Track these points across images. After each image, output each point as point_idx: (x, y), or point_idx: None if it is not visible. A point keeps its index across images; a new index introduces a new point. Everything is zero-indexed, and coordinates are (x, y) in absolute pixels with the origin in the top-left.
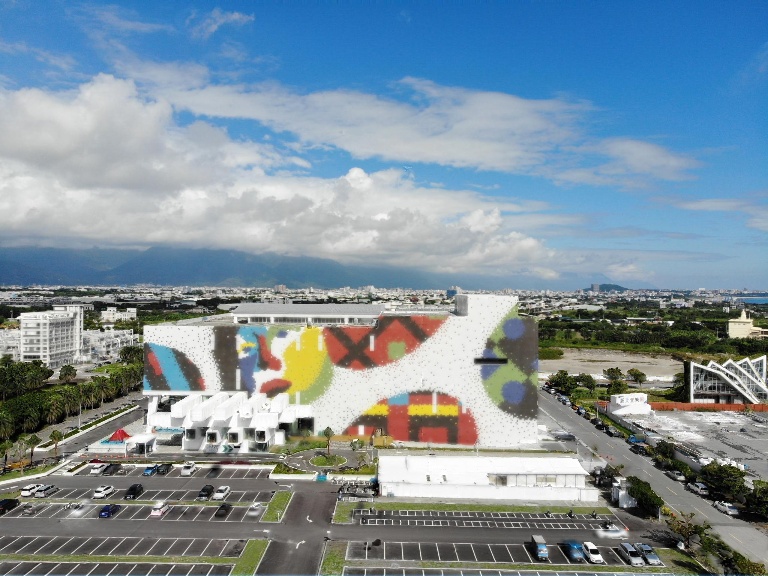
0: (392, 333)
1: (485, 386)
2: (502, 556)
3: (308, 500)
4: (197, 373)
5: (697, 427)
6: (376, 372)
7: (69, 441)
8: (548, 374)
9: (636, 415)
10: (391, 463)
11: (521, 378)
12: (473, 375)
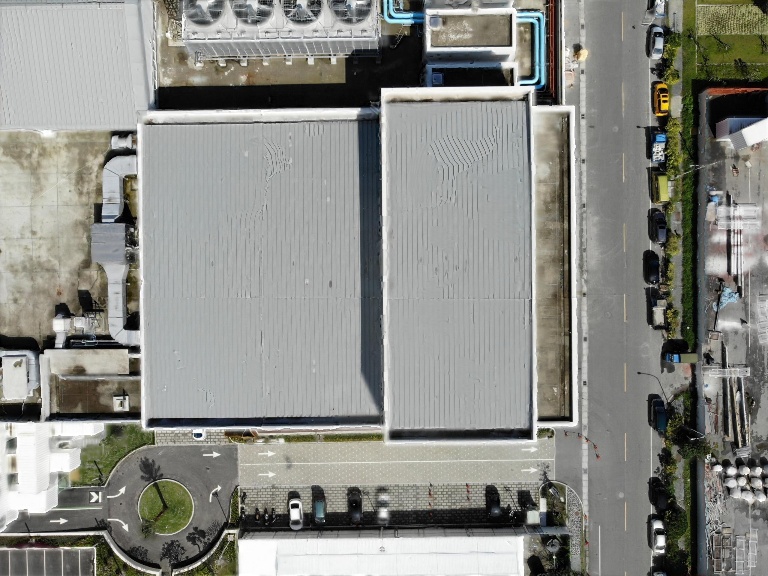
0: None
1: None
2: None
3: None
4: None
5: None
6: None
7: None
8: None
9: (767, 148)
10: (256, 572)
11: None
12: None
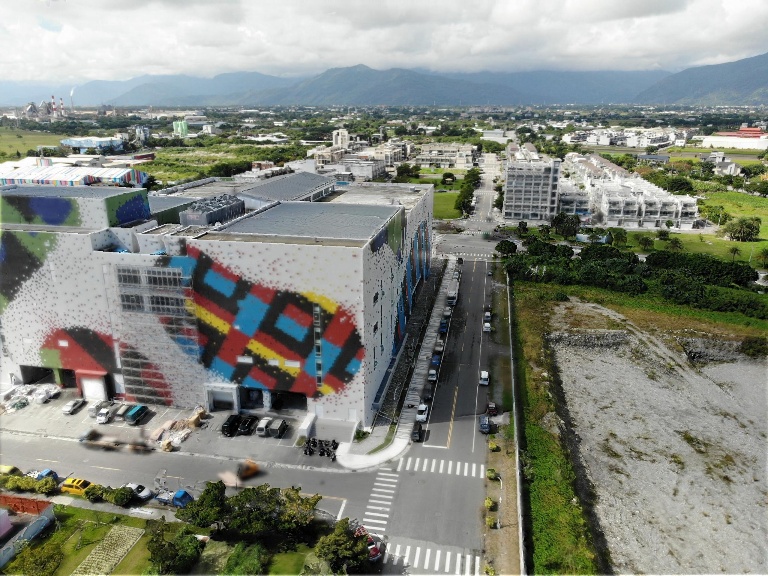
0: None
1: None
2: None
3: None
4: None
5: None
6: None
7: None
8: None
9: None
10: None
11: None
12: None
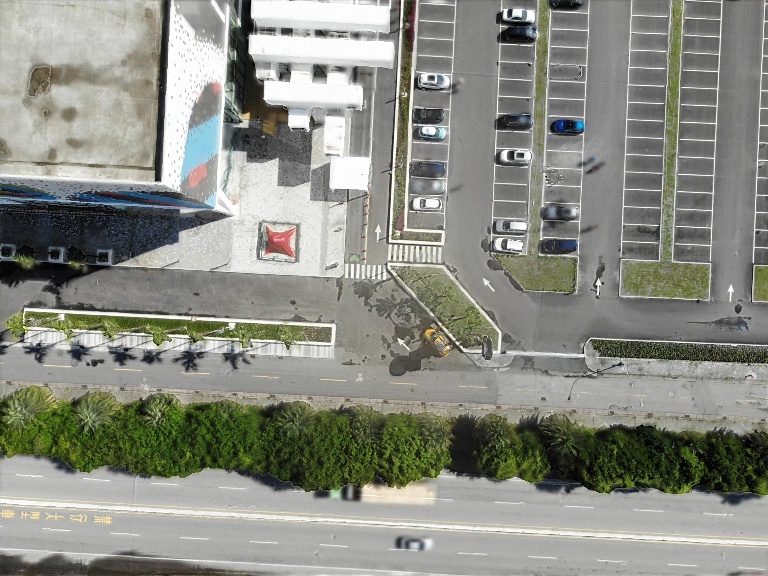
0: None
1: None
2: None
3: None
4: (210, 91)
5: None
6: None
7: (280, 321)
8: None
9: None
10: None
11: None
12: None
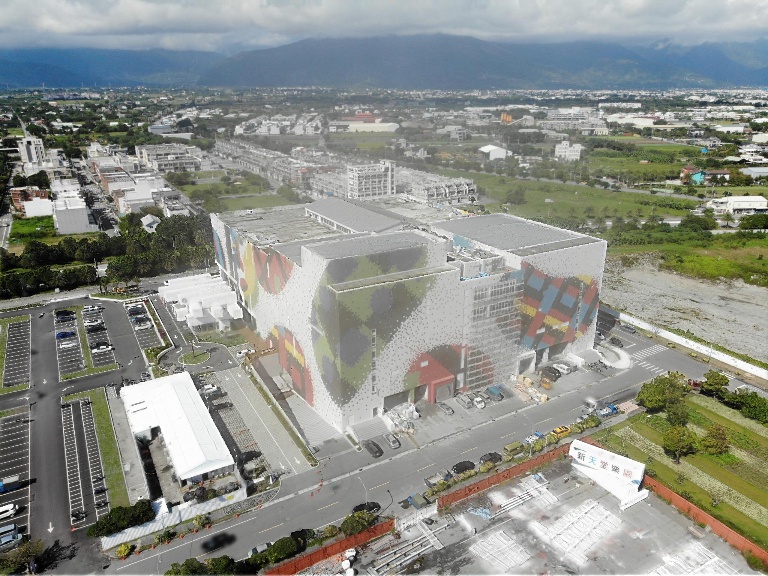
0: (274, 265)
1: (314, 350)
2: (6, 473)
3: (103, 377)
4: None
5: (596, 563)
6: (272, 298)
7: None
8: (760, 369)
9: (599, 489)
10: (169, 380)
11: (331, 357)
12: (308, 333)
